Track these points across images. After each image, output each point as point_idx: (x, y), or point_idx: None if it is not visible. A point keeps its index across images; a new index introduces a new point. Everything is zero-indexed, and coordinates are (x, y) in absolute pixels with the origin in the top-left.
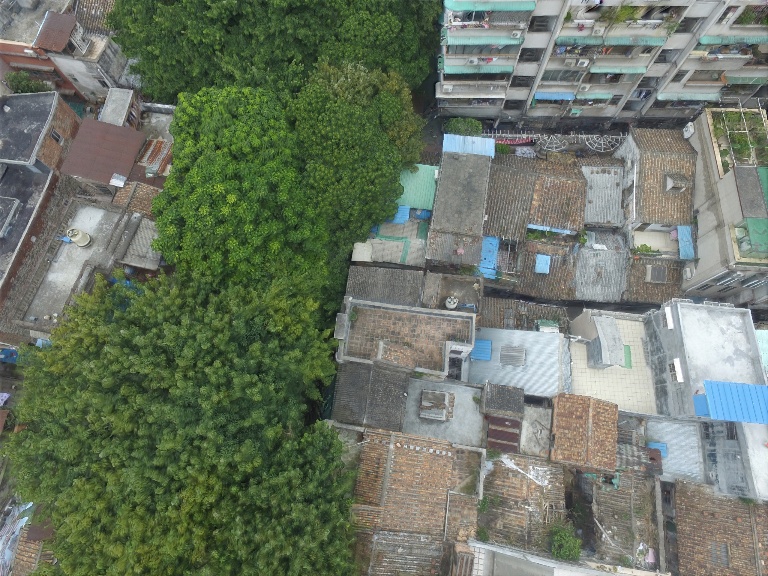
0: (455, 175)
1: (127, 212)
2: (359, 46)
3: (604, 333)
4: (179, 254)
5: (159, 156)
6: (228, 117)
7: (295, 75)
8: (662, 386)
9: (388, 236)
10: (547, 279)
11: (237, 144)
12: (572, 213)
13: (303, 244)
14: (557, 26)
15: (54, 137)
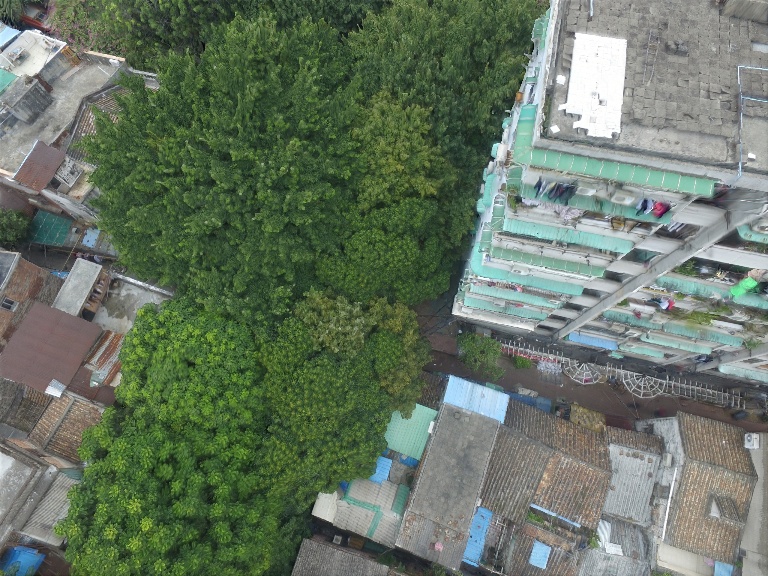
0: (452, 441)
1: (41, 465)
2: (365, 270)
3: None
4: (80, 556)
5: (112, 358)
6: (182, 367)
7: (282, 298)
8: None
9: (358, 500)
10: (542, 571)
11: (184, 408)
12: (587, 506)
13: None
14: (607, 301)
15: (5, 305)
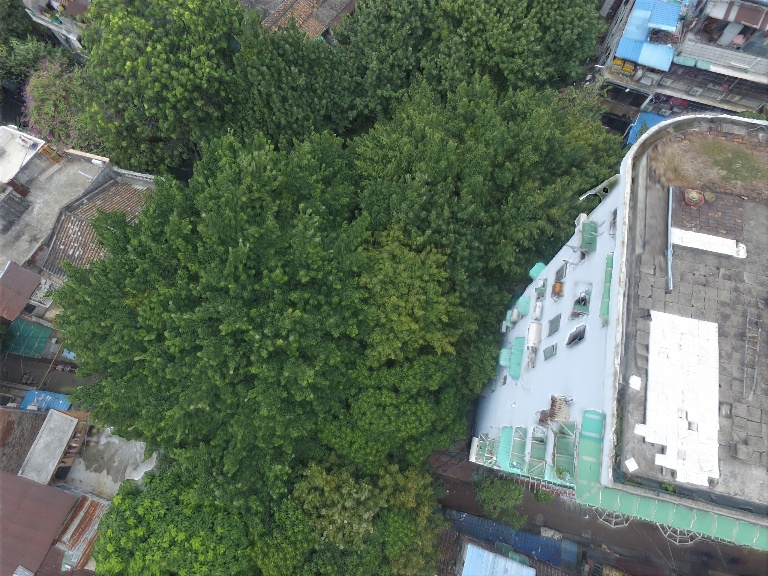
0: None
1: None
2: None
3: None
4: None
5: (87, 533)
6: None
7: None
8: None
9: None
10: None
11: None
12: None
13: None
14: None
15: None
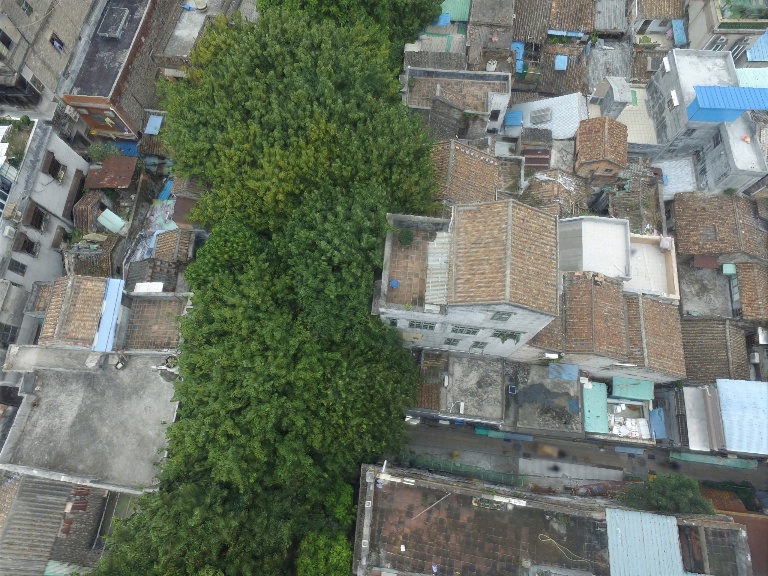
0: None
1: None
2: None
3: (615, 83)
4: (280, 7)
5: None
6: None
7: None
8: (662, 124)
9: (434, 33)
10: (565, 77)
11: None
12: (585, 17)
13: (374, 9)
14: None
15: None
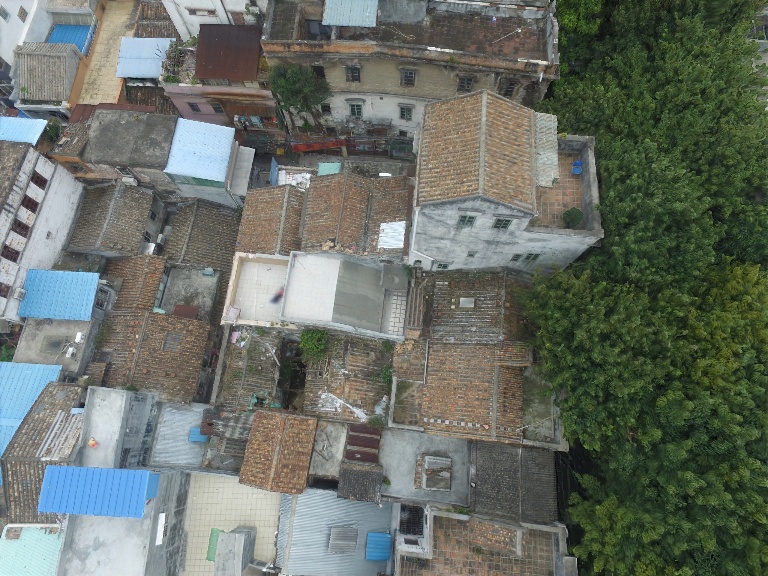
0: None
1: None
2: None
3: None
4: None
5: None
6: None
7: None
8: (179, 507)
9: None
10: None
11: None
12: None
13: None
14: None
15: None
